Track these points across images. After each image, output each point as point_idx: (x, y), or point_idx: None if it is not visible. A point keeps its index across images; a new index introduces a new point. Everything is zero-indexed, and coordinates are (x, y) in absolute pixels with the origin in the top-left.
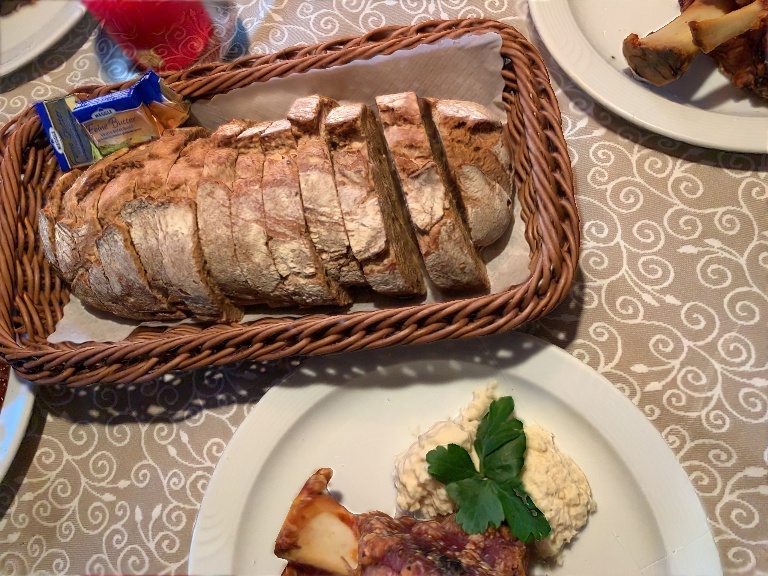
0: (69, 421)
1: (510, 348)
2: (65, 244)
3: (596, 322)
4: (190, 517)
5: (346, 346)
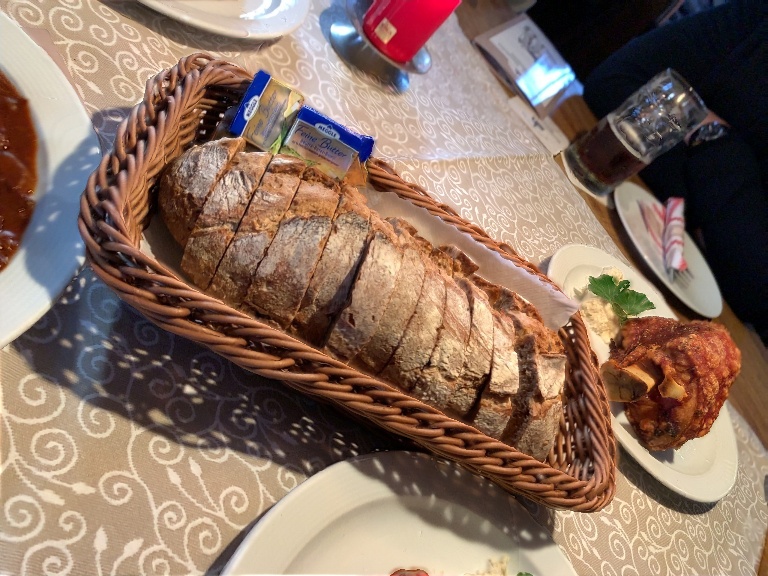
0: (30, 365)
1: (531, 532)
2: (236, 193)
3: (560, 544)
4: (174, 574)
5: (472, 455)
